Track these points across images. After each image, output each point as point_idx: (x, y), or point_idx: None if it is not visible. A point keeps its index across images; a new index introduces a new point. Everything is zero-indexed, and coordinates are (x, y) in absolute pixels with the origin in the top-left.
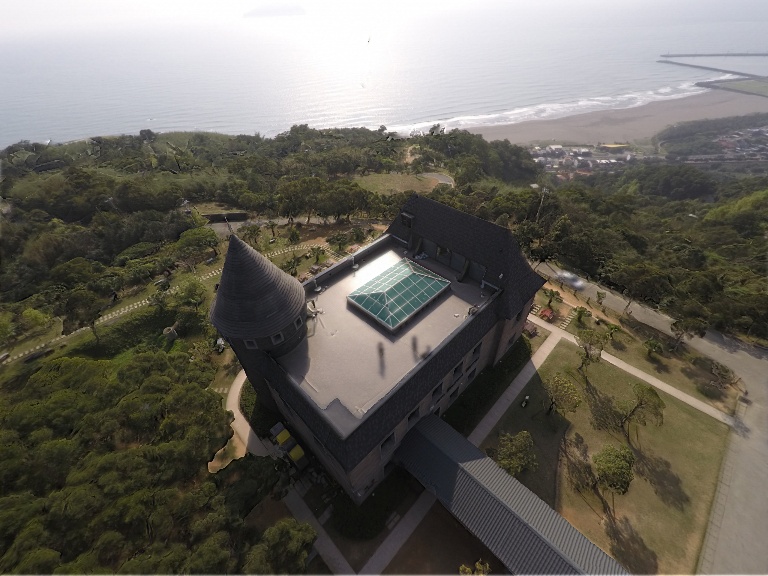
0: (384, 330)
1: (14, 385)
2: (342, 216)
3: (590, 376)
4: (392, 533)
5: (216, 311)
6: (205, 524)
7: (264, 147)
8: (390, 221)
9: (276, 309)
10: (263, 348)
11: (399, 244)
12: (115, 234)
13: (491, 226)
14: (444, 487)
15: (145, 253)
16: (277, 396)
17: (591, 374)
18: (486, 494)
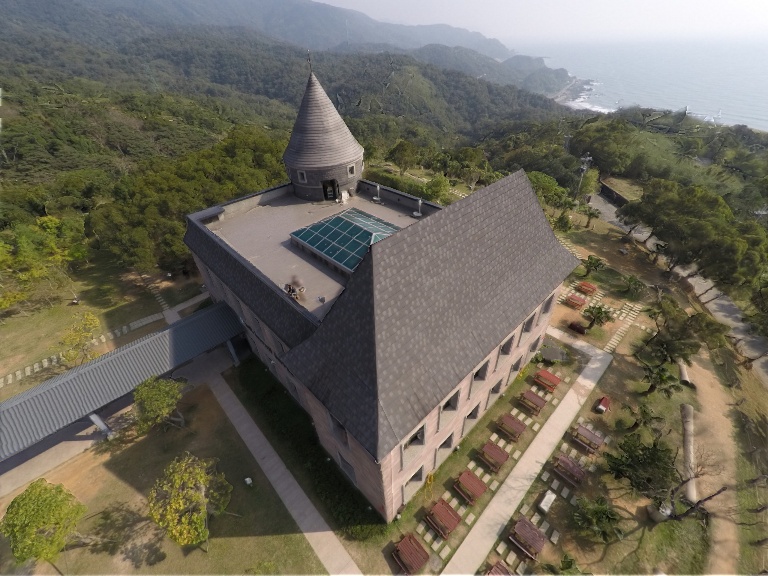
0: None
1: (370, 174)
2: (679, 268)
3: None
4: None
5: None
6: None
7: None
8: None
9: (296, 148)
10: None
11: None
12: (536, 161)
13: None
14: None
15: None
16: None
17: None
18: None
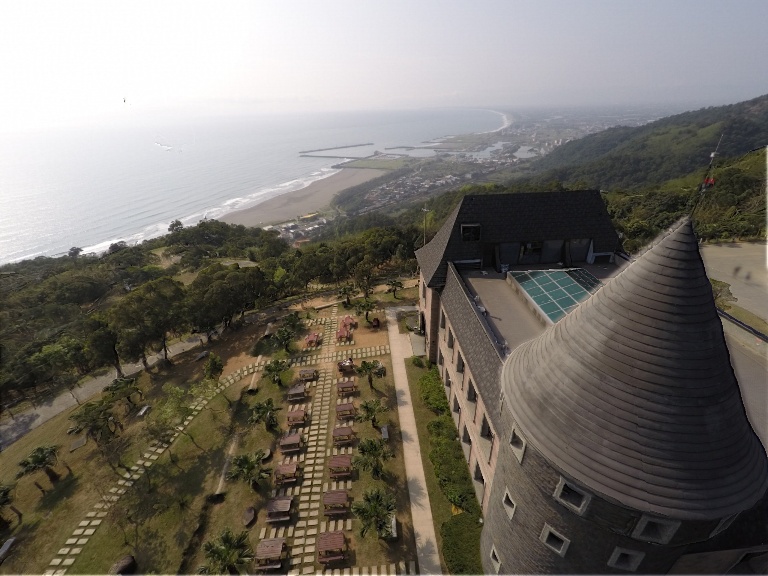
0: None
1: None
2: (235, 317)
3: None
4: None
5: (697, 471)
6: None
7: None
8: (272, 307)
9: None
10: None
11: (465, 269)
12: None
13: (579, 194)
14: None
15: None
16: (701, 575)
17: None
18: None
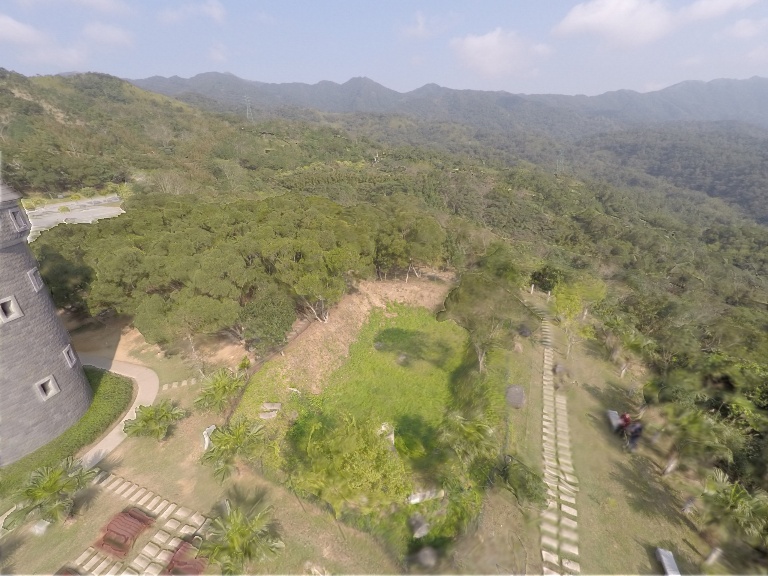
0: None
1: None
2: None
3: None
4: None
5: None
6: (72, 243)
7: None
8: None
9: None
10: None
11: None
12: None
13: None
14: None
15: None
16: None
17: None
18: None
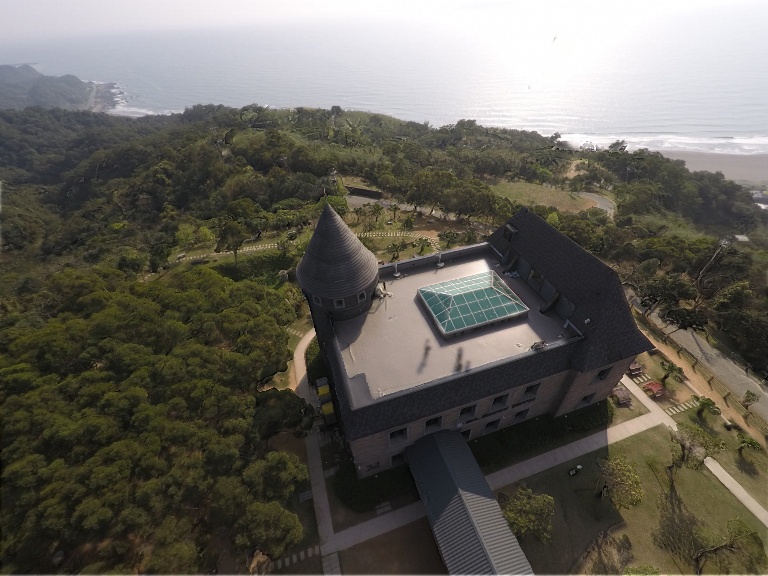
0: (438, 332)
1: None
2: (463, 215)
3: (680, 483)
4: (378, 518)
5: (301, 264)
6: (234, 424)
7: (427, 136)
8: None
9: (345, 278)
10: (326, 308)
11: (495, 255)
12: (279, 187)
13: (596, 262)
14: (436, 503)
15: (293, 207)
16: None
17: (683, 481)
18: (473, 532)
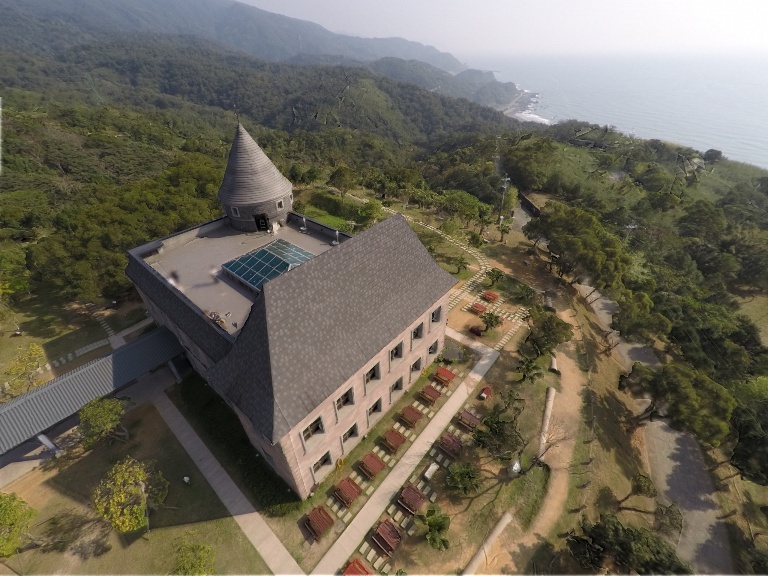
0: None
1: None
2: (565, 276)
3: None
4: None
5: None
6: (141, 234)
7: None
8: (657, 358)
9: (228, 187)
10: None
11: None
12: (469, 179)
13: None
14: None
15: None
16: None
17: None
18: None
